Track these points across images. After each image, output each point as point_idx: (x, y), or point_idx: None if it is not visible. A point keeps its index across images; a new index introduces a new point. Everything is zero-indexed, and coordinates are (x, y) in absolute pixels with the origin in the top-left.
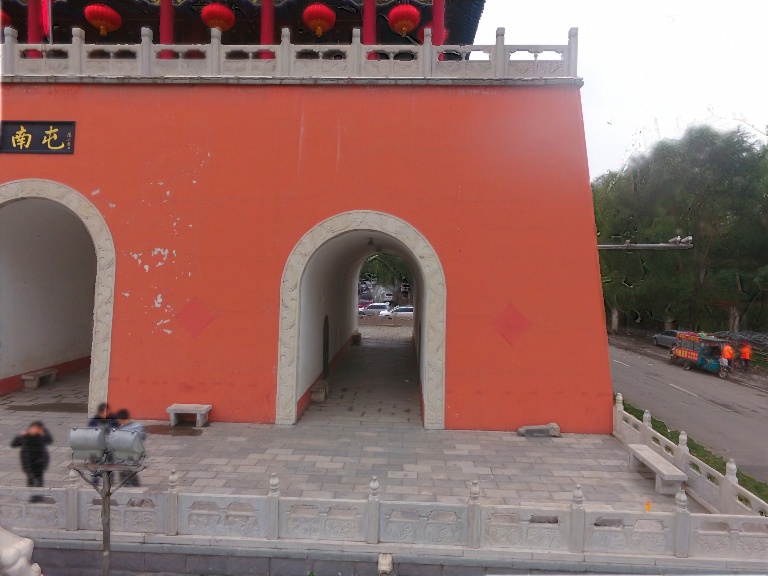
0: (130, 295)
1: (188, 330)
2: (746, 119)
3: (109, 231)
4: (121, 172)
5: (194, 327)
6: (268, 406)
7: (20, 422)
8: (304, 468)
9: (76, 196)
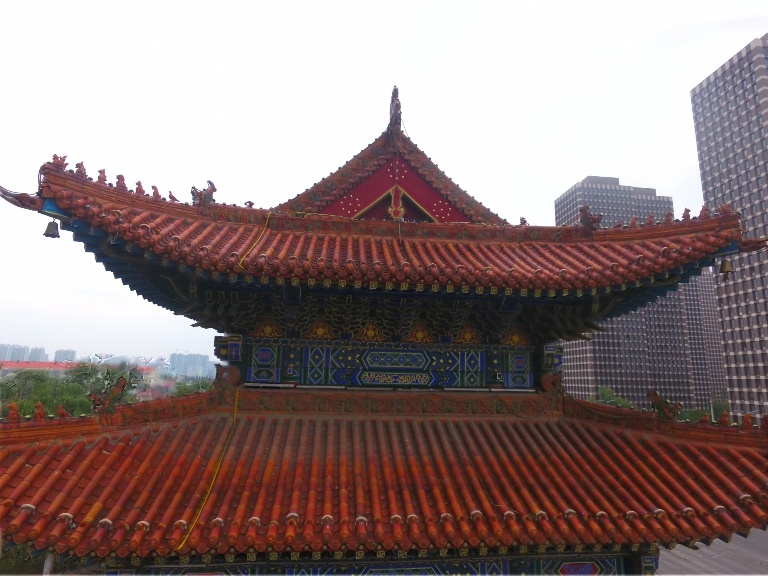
0: None
1: None
2: (174, 369)
3: None
4: None
5: None
6: None
7: None
8: None
9: None
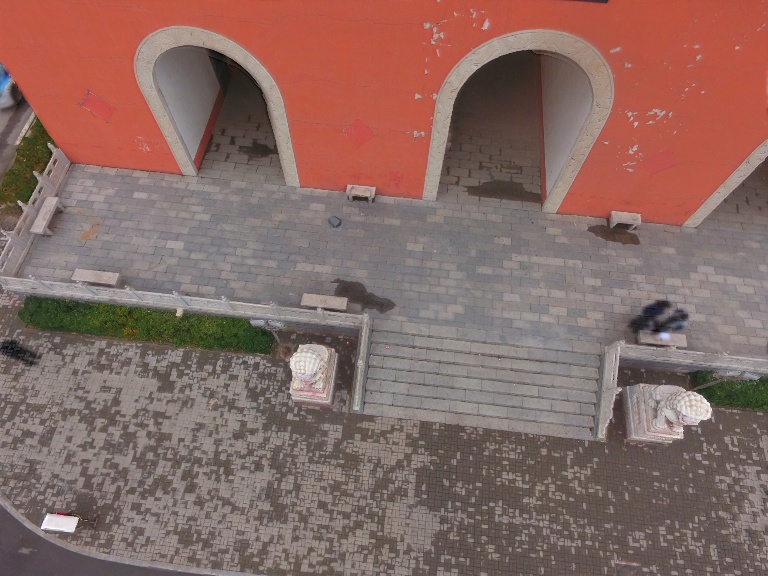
0: (609, 143)
1: (648, 170)
2: None
3: (614, 91)
4: (655, 29)
5: (654, 169)
6: (683, 217)
7: (502, 218)
8: (732, 293)
9: (592, 53)
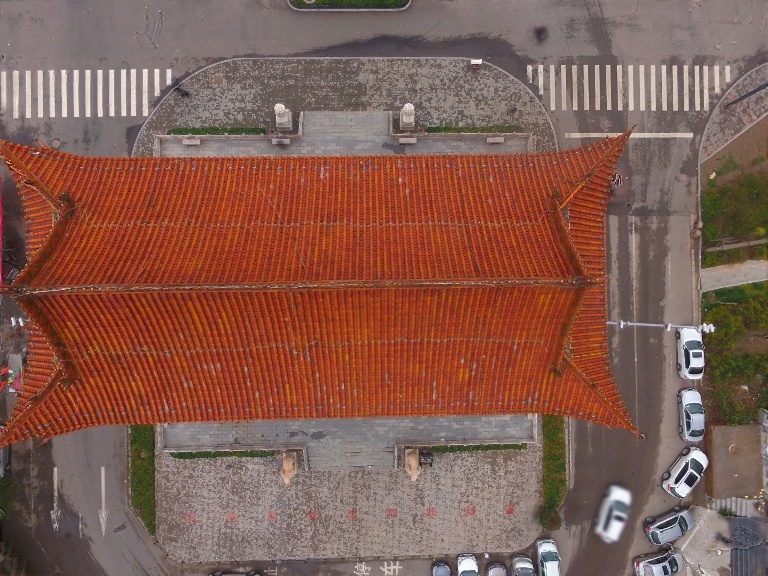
0: None
1: None
2: None
3: None
4: None
5: None
6: None
7: None
8: None
9: None
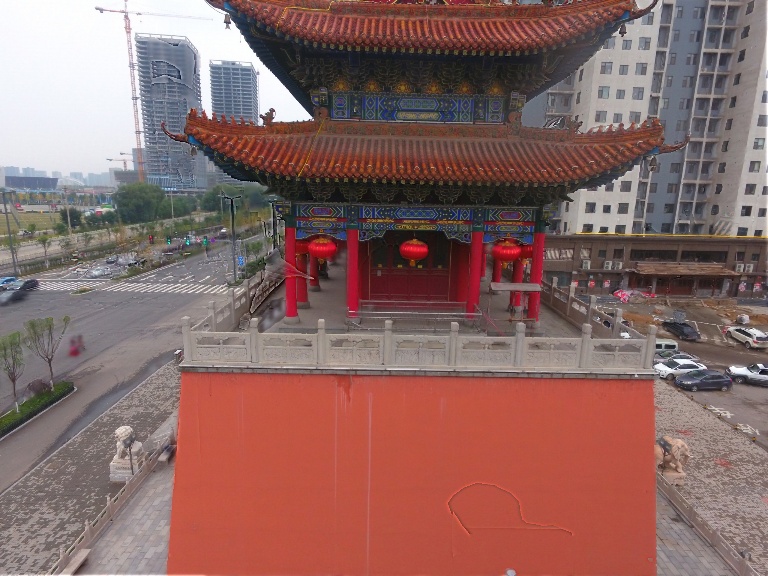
0: None
1: None
2: None
3: None
4: None
5: None
6: None
7: None
8: None
9: None
